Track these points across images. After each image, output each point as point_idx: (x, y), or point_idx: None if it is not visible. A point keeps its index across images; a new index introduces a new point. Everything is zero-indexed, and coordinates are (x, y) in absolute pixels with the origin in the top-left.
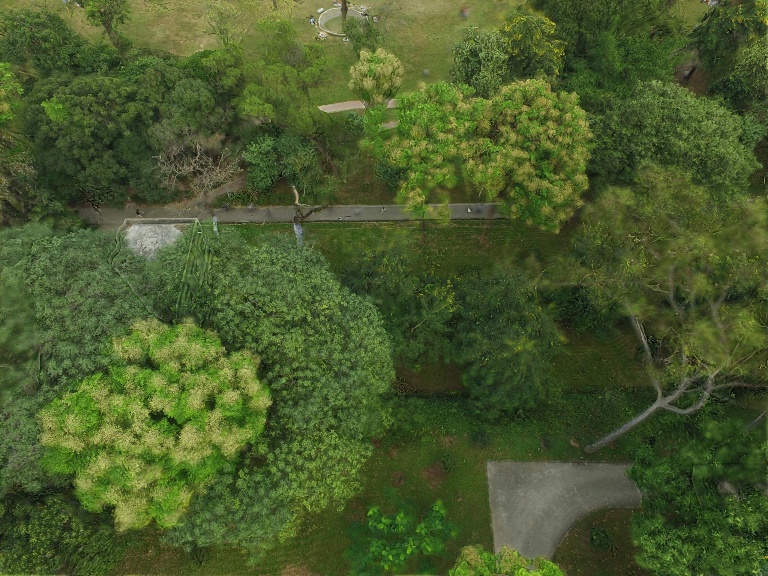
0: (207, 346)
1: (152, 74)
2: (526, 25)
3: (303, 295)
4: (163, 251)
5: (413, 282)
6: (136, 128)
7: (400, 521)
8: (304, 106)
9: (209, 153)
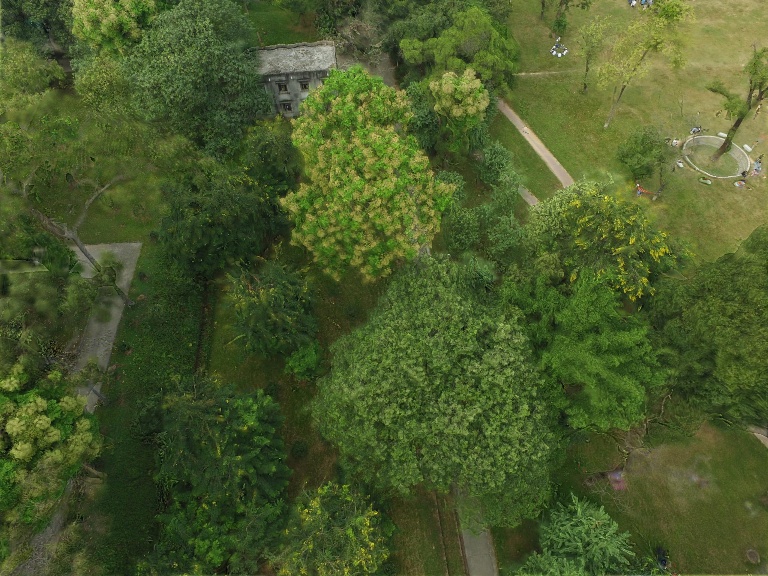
0: (131, 4)
1: (447, 2)
2: (596, 203)
3: (172, 43)
4: (312, 63)
5: (258, 162)
6: (404, 18)
7: (60, 120)
8: (436, 79)
9: (402, 62)
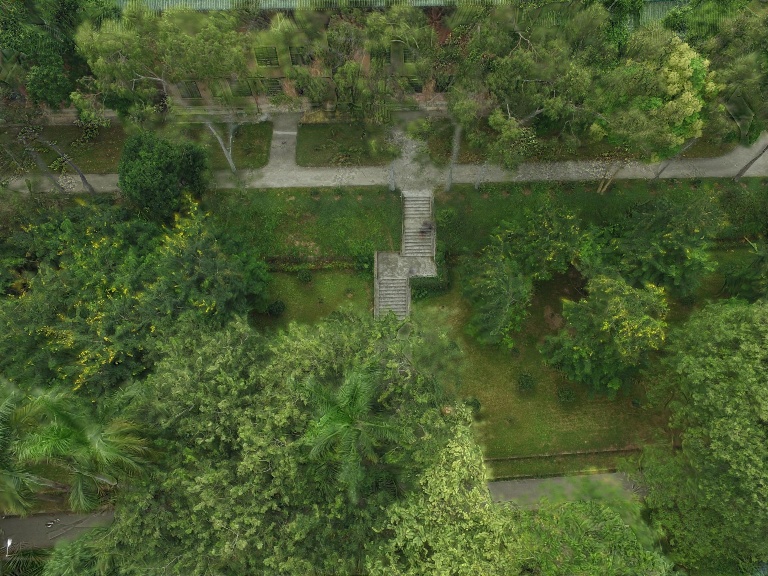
0: None
1: None
2: None
3: None
4: None
5: None
6: None
7: None
8: None
9: None
